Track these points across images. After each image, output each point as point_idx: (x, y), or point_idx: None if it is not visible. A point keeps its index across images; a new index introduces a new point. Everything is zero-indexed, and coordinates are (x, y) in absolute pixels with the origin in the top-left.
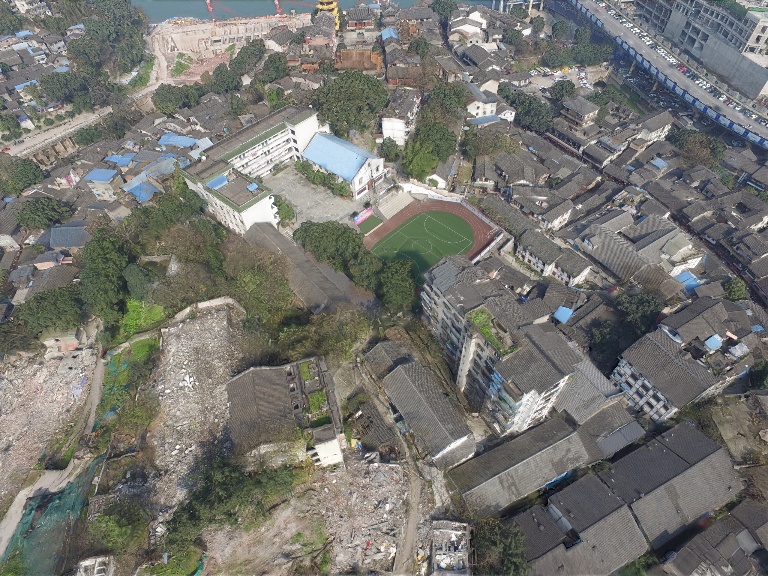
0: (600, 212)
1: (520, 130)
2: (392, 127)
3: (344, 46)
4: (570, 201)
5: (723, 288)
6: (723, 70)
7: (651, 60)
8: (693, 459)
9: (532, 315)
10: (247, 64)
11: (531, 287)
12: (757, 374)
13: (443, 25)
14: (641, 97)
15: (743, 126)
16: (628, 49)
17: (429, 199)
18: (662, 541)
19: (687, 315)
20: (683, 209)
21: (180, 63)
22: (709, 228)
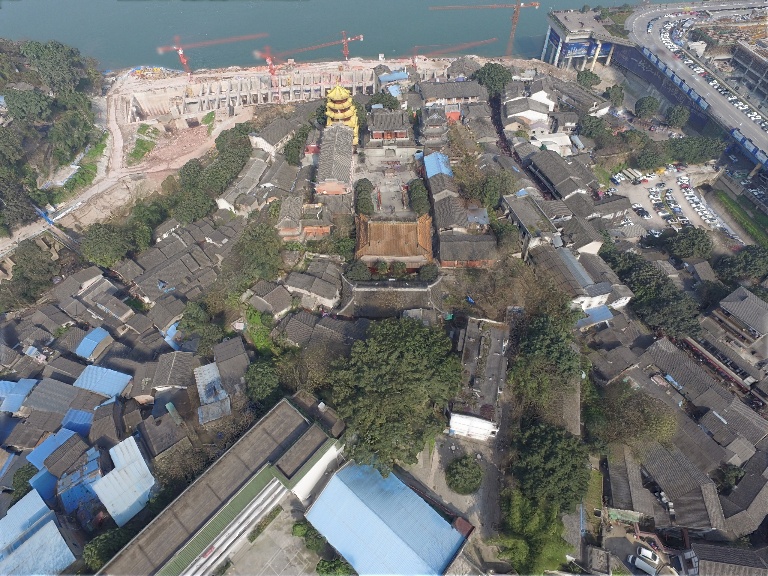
0: None
1: (640, 327)
2: (469, 423)
3: (368, 184)
4: None
5: None
6: None
7: None
8: None
9: None
10: (224, 181)
11: None
12: None
13: (492, 101)
14: None
15: None
16: (754, 151)
17: None
18: None
19: None
20: None
21: (141, 141)
22: None
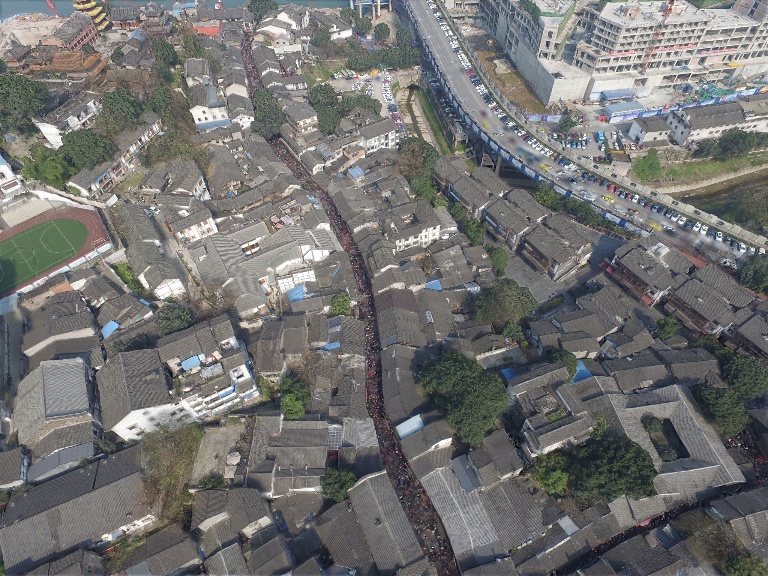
0: (247, 222)
1: (256, 135)
2: (50, 132)
3: (88, 47)
4: (208, 211)
5: (331, 302)
6: (528, 75)
7: (447, 64)
8: (100, 484)
9: (56, 330)
10: None
11: (106, 300)
12: (284, 393)
13: None
14: (436, 102)
15: (495, 134)
16: (428, 53)
17: (68, 207)
18: (20, 569)
19: (184, 333)
20: (348, 220)
21: None
22: (363, 240)
